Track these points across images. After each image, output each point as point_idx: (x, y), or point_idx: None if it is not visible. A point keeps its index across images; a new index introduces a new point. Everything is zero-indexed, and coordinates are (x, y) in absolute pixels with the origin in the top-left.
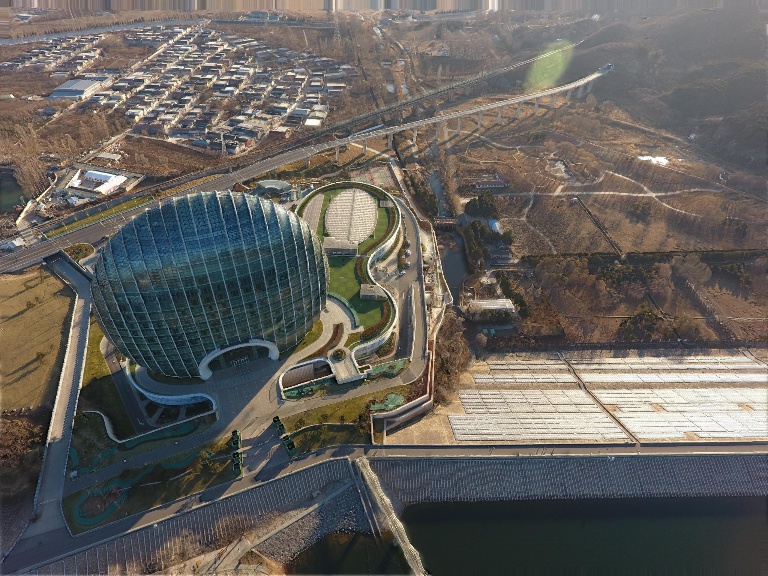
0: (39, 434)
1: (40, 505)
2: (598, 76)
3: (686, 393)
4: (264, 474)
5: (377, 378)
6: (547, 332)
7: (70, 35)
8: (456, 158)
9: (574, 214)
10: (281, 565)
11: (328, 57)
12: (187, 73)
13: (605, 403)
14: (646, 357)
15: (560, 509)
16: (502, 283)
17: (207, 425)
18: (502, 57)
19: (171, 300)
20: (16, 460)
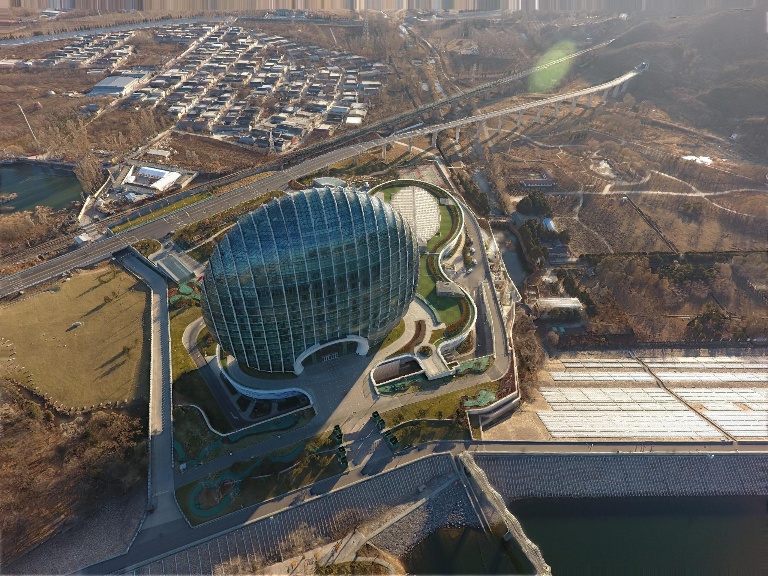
0: (140, 427)
1: (154, 496)
2: (634, 75)
3: (766, 392)
4: (370, 468)
5: (465, 374)
6: (615, 331)
7: (100, 32)
8: (500, 157)
9: (626, 213)
10: (397, 558)
11: (359, 55)
12: (222, 70)
13: (689, 401)
14: (717, 356)
15: (664, 506)
16: (565, 281)
17: (307, 419)
18: (532, 56)
19: (283, 295)
20: (122, 452)
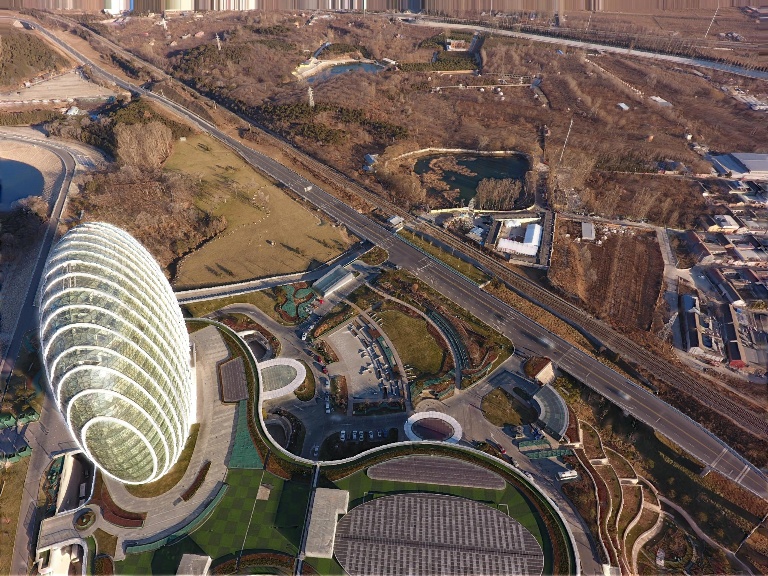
0: None
1: None
2: None
3: None
4: None
5: None
6: None
7: None
8: None
9: None
10: None
11: None
12: None
13: None
14: None
15: None
16: None
17: None
18: None
19: None
20: None
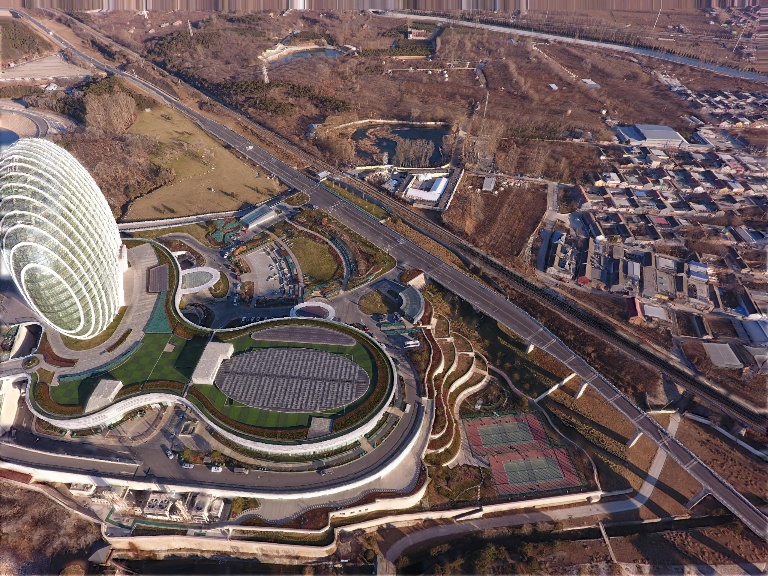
0: None
1: None
2: None
3: None
4: None
5: None
6: None
7: None
8: None
9: None
10: None
11: None
12: None
13: None
14: None
15: None
16: None
17: None
18: None
19: None
20: None
